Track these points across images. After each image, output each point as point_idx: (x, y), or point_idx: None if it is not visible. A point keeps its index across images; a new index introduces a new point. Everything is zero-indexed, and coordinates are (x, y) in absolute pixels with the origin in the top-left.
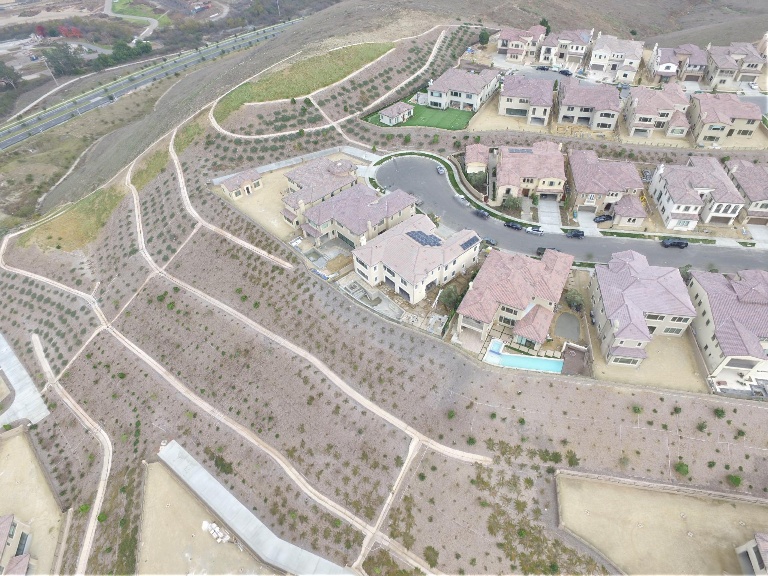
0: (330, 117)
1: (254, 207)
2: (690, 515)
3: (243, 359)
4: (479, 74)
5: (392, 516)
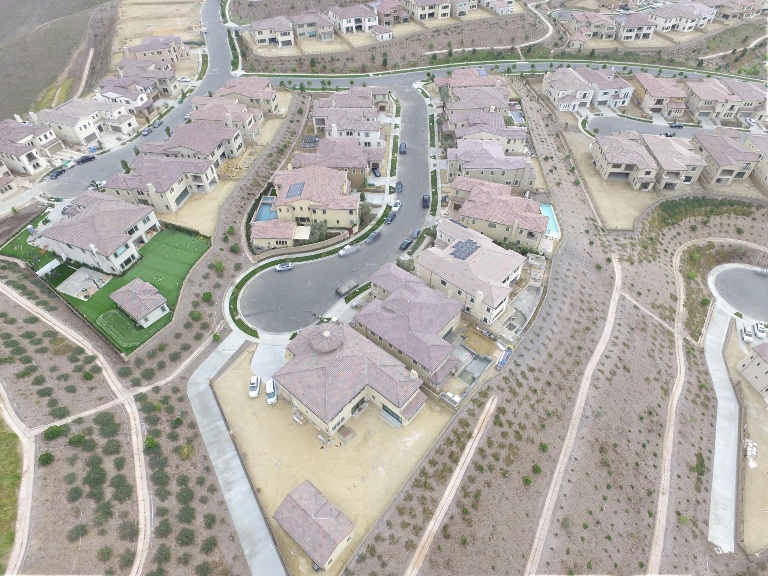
0: (103, 402)
1: (371, 488)
2: (595, 189)
3: (610, 454)
4: (89, 206)
5: (665, 319)
